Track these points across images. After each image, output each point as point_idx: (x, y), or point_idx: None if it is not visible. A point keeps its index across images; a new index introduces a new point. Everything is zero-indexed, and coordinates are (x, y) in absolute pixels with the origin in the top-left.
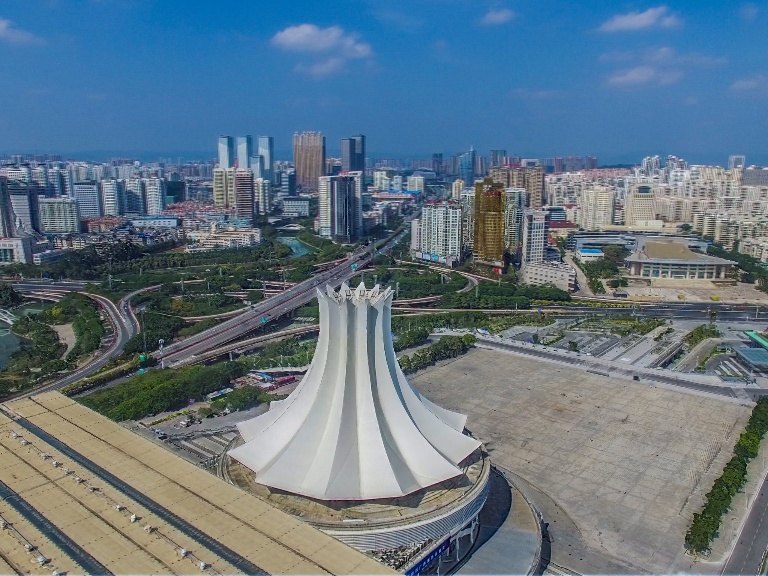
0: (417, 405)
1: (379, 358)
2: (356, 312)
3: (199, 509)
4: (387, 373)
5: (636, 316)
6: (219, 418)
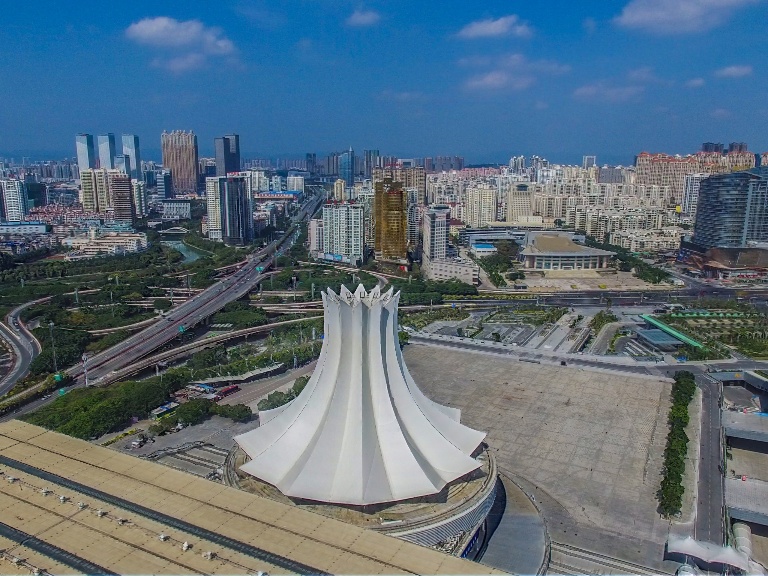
0: (424, 403)
1: (390, 359)
2: (369, 314)
3: (250, 529)
4: (399, 373)
5: (541, 306)
6: (172, 435)
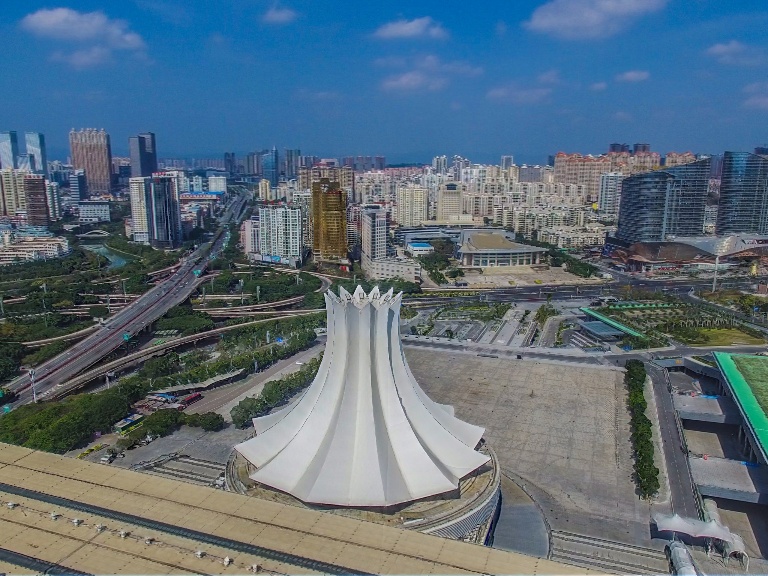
0: (426, 401)
1: (395, 359)
2: (376, 315)
3: (287, 538)
4: (404, 373)
5: (485, 302)
6: (142, 448)
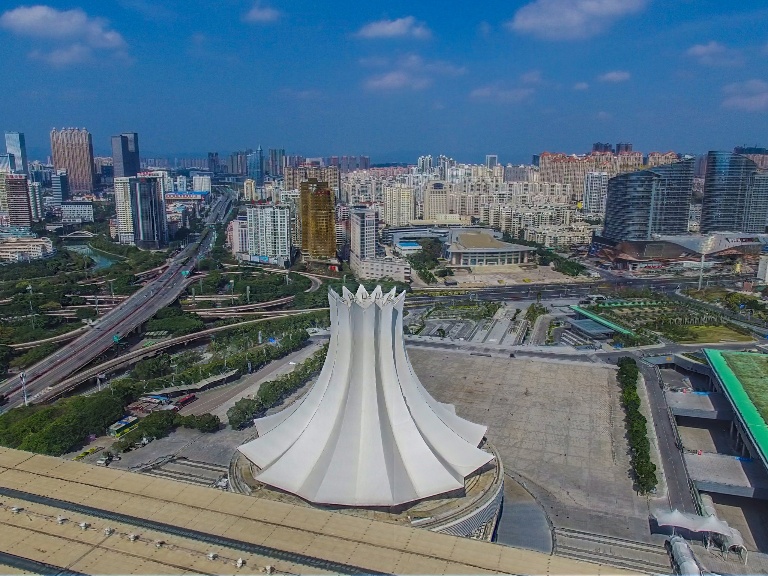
0: (429, 400)
1: (399, 358)
2: (380, 314)
3: (298, 539)
4: (408, 372)
5: (475, 301)
6: (138, 450)
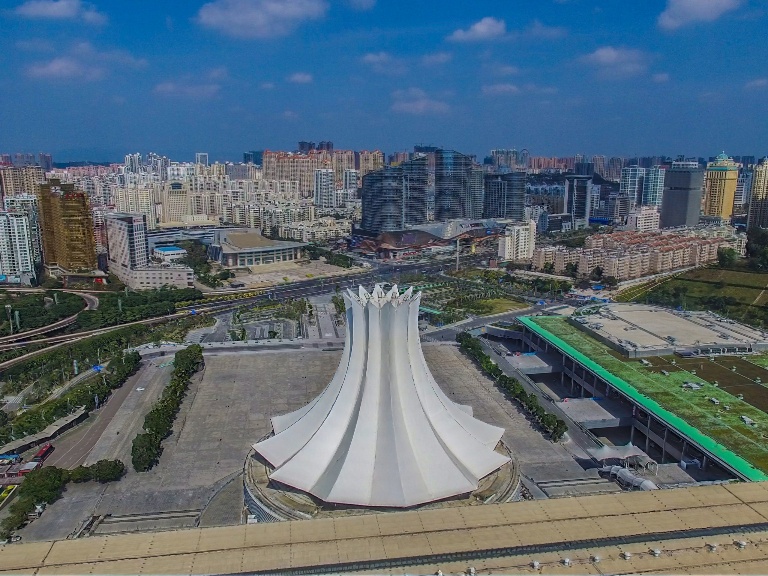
0: None
1: None
2: (409, 312)
3: (458, 538)
4: None
5: None
6: (37, 522)
